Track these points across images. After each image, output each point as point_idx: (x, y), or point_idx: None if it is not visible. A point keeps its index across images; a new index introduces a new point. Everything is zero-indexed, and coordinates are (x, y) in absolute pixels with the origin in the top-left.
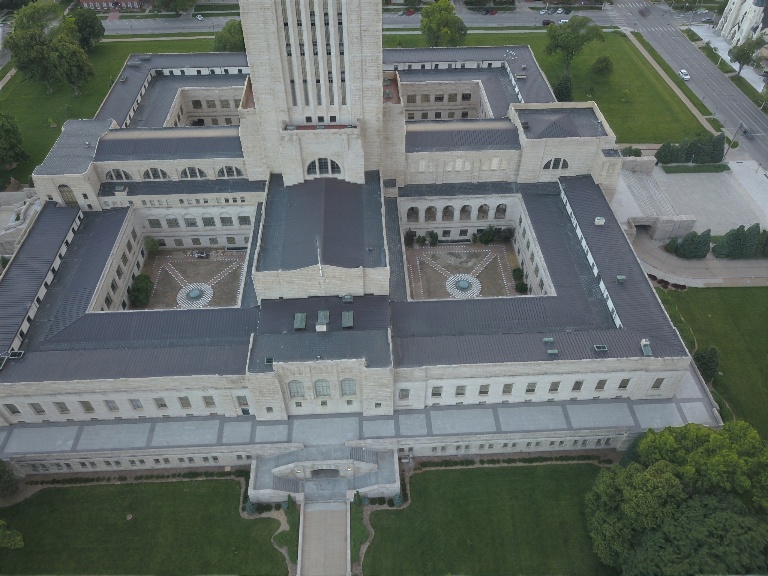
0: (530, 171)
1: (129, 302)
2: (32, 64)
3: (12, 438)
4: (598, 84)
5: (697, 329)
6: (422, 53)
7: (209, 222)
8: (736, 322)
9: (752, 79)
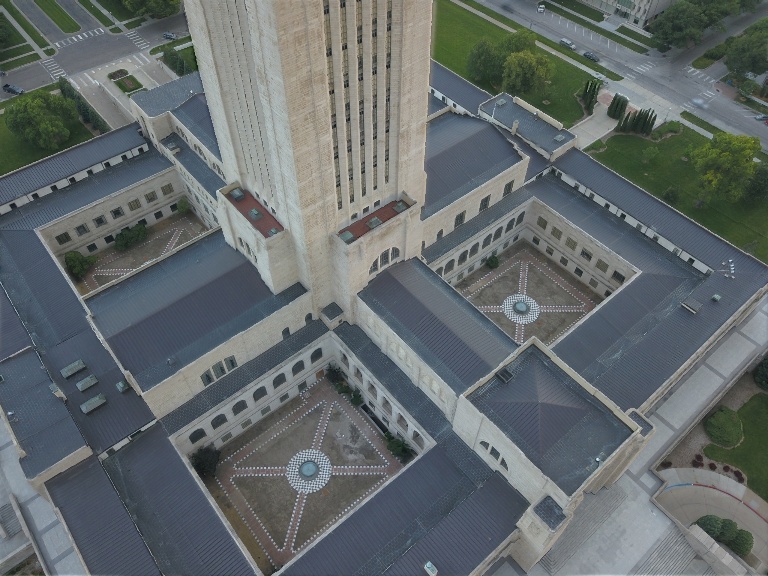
0: (465, 431)
1: None
2: None
3: None
4: None
5: None
6: (624, 189)
7: None
8: None
9: None
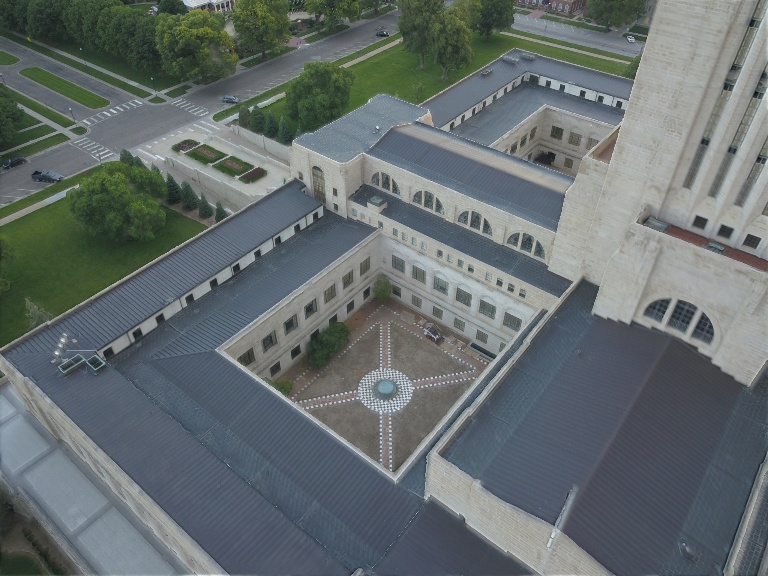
0: None
1: (306, 350)
2: (415, 32)
3: (46, 460)
4: None
5: None
6: None
7: (464, 298)
8: None
9: None
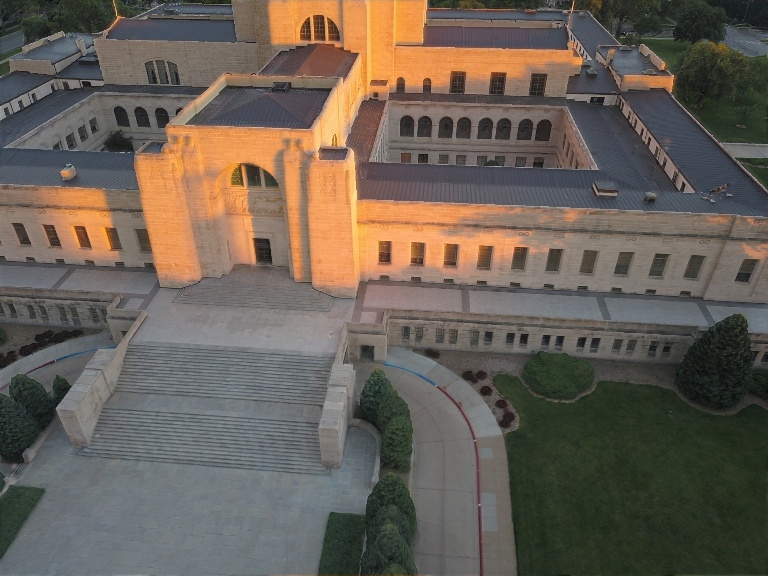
0: None
1: None
2: None
3: None
4: None
5: None
6: (676, 120)
7: None
8: None
9: None
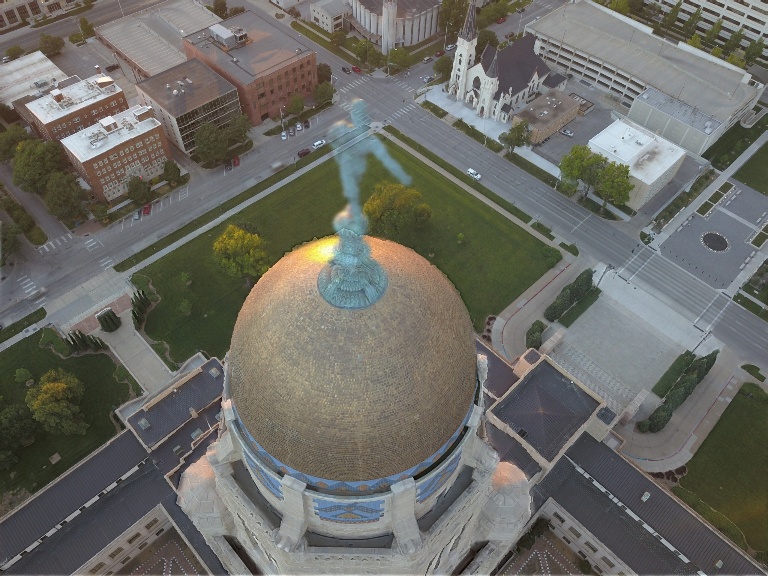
0: None
1: None
2: None
3: None
4: (423, 231)
5: (727, 512)
6: None
7: None
8: (738, 480)
9: (523, 152)
